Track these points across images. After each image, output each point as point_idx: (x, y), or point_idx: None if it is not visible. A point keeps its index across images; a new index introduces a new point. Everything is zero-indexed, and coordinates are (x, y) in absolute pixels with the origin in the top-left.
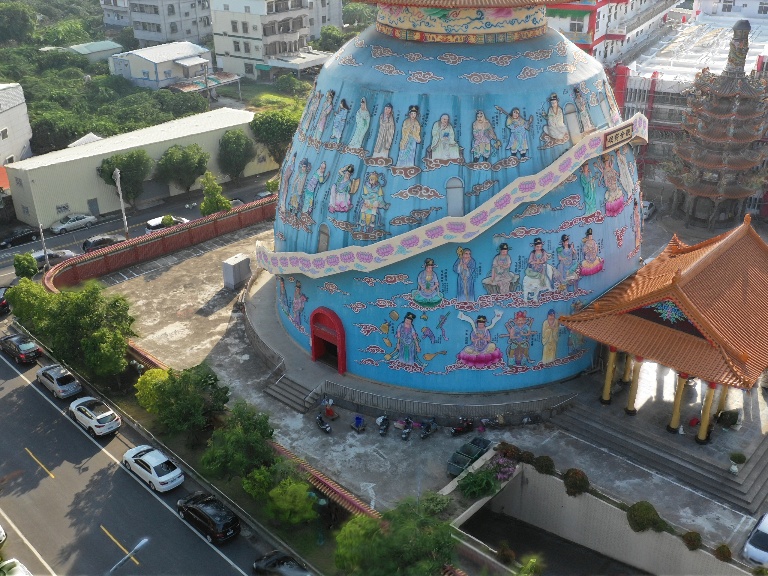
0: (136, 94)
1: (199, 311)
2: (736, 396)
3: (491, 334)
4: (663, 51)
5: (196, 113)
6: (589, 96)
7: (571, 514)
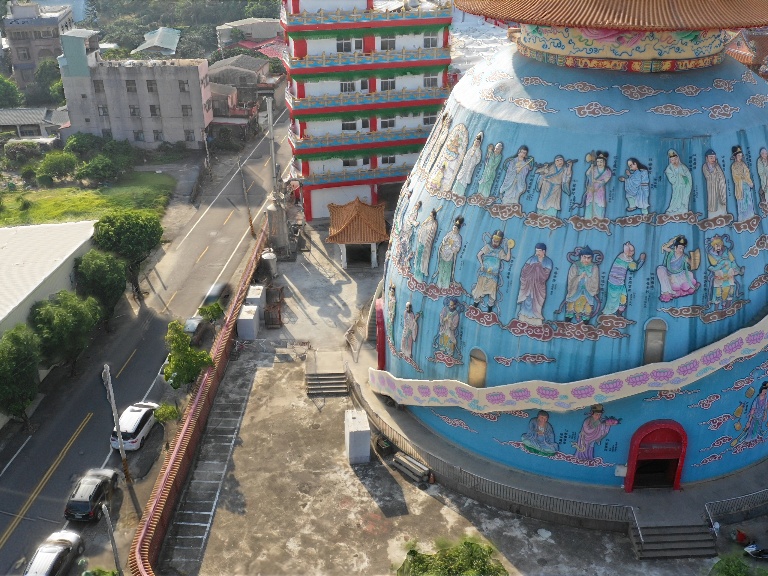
0: None
1: (386, 512)
2: None
3: None
4: (452, 57)
5: None
6: None
7: None
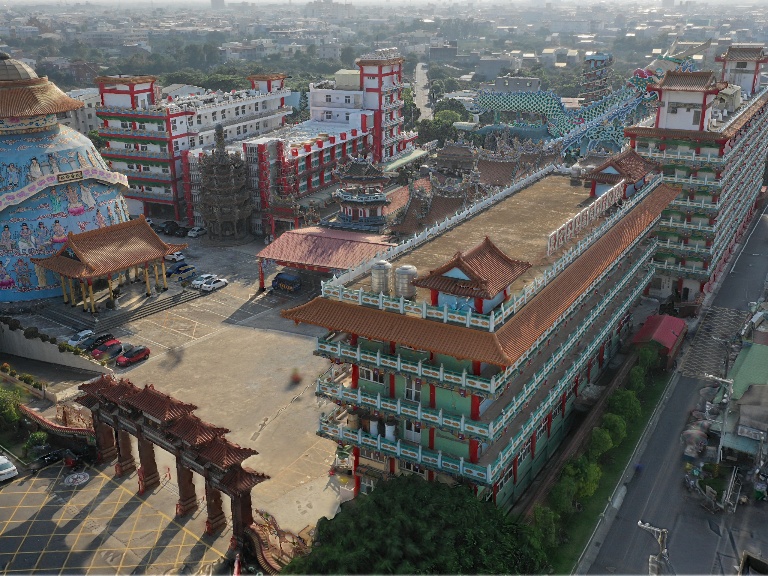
0: None
1: None
2: (133, 300)
3: (6, 270)
4: None
5: None
6: (61, 159)
7: (17, 342)
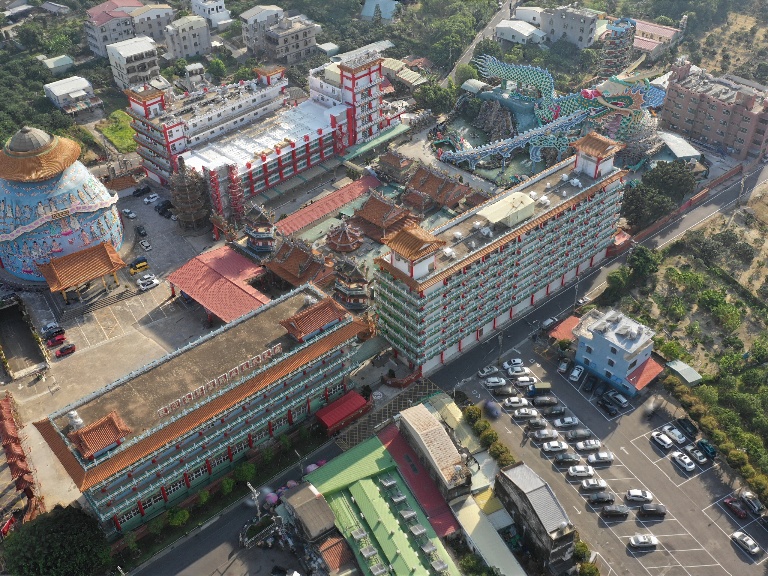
0: (42, 114)
1: None
2: None
3: (28, 265)
4: None
5: (61, 130)
6: (57, 201)
7: None
